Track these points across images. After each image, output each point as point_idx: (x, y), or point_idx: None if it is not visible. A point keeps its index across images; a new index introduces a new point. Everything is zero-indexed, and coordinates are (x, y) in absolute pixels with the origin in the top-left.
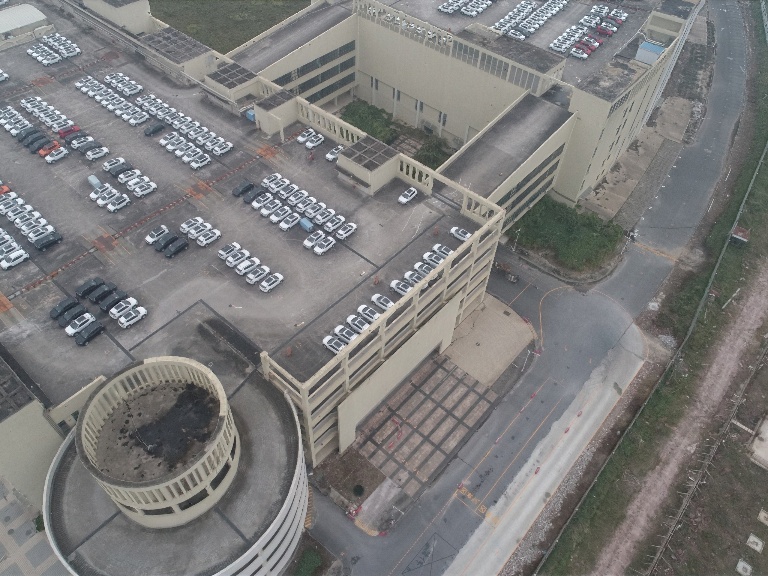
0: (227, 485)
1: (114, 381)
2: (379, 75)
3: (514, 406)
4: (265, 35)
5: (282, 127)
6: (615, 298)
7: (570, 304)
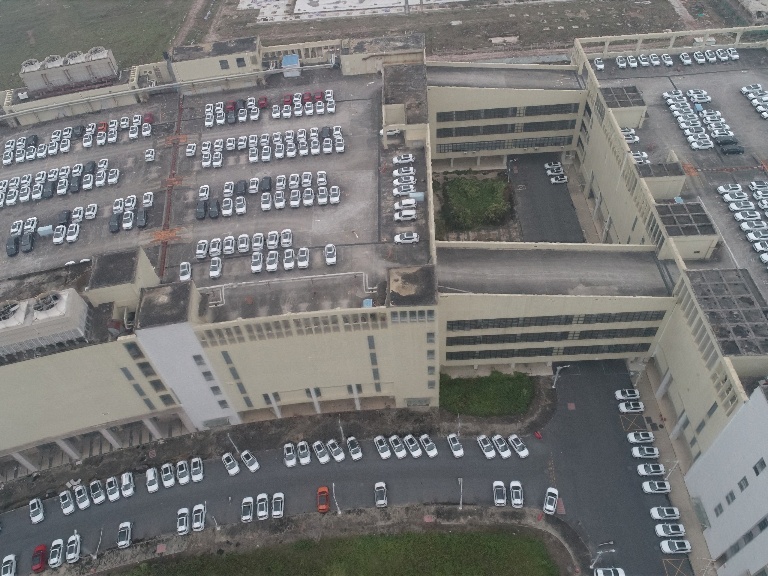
0: None
1: None
2: None
3: None
4: (572, 299)
5: (668, 158)
6: None
7: None
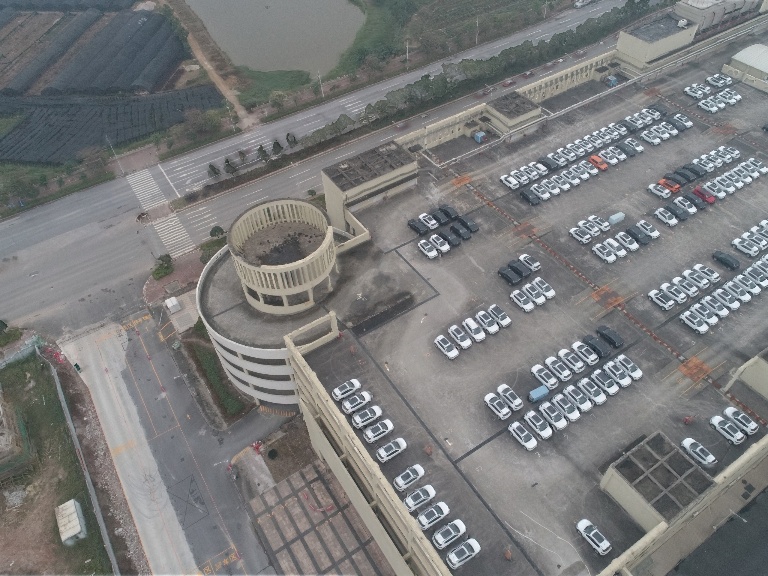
0: None
1: None
2: None
3: None
4: None
5: None
6: None
7: None
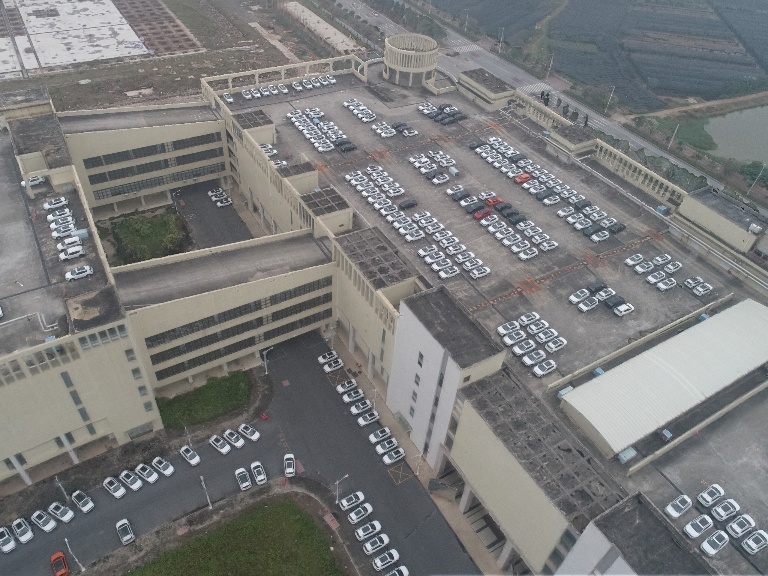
0: None
1: None
2: None
3: None
4: (254, 285)
5: (302, 161)
6: None
7: None
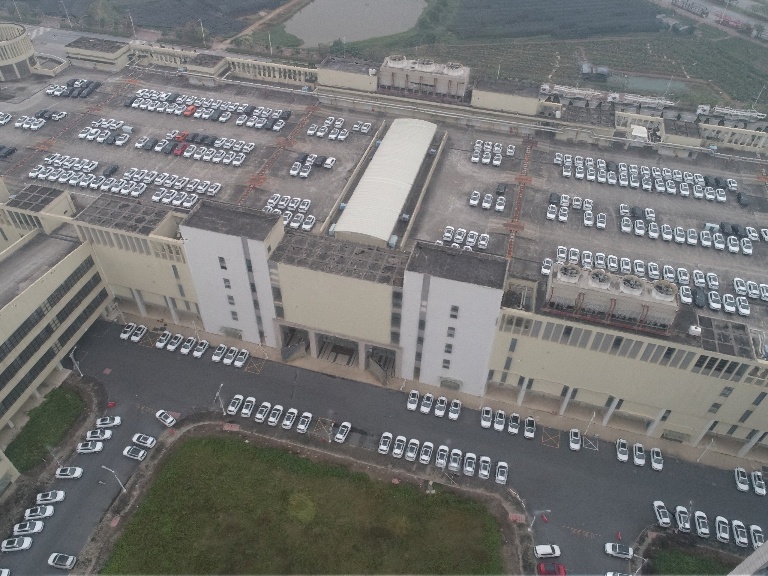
0: None
1: None
2: None
3: None
4: (27, 293)
5: None
6: None
7: None
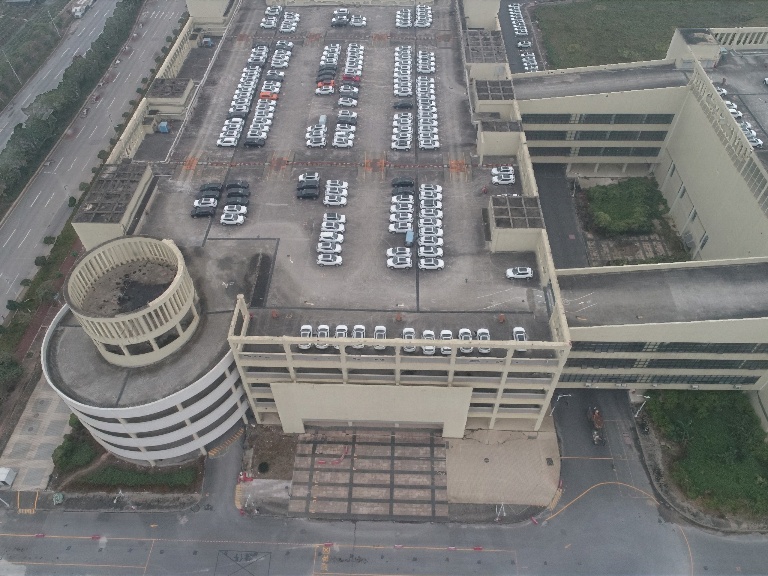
0: (146, 362)
1: (140, 239)
2: (678, 162)
3: (450, 538)
4: (578, 71)
5: None
6: (696, 559)
7: (631, 515)
